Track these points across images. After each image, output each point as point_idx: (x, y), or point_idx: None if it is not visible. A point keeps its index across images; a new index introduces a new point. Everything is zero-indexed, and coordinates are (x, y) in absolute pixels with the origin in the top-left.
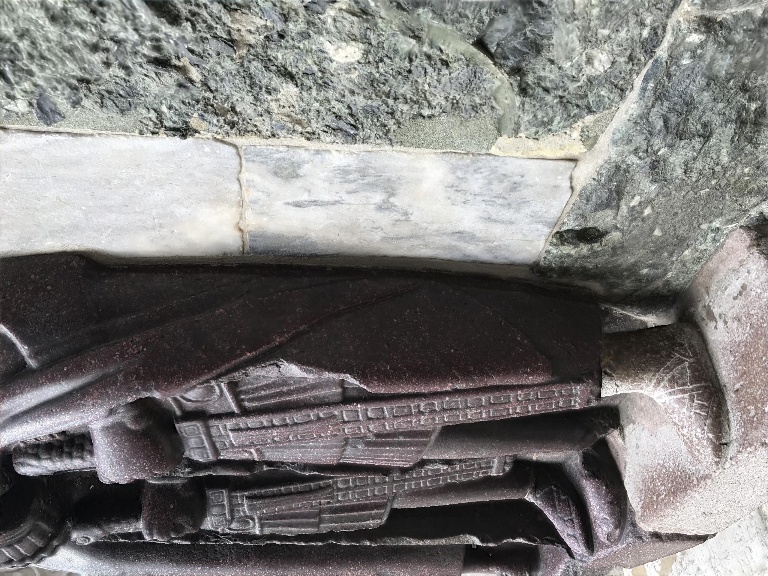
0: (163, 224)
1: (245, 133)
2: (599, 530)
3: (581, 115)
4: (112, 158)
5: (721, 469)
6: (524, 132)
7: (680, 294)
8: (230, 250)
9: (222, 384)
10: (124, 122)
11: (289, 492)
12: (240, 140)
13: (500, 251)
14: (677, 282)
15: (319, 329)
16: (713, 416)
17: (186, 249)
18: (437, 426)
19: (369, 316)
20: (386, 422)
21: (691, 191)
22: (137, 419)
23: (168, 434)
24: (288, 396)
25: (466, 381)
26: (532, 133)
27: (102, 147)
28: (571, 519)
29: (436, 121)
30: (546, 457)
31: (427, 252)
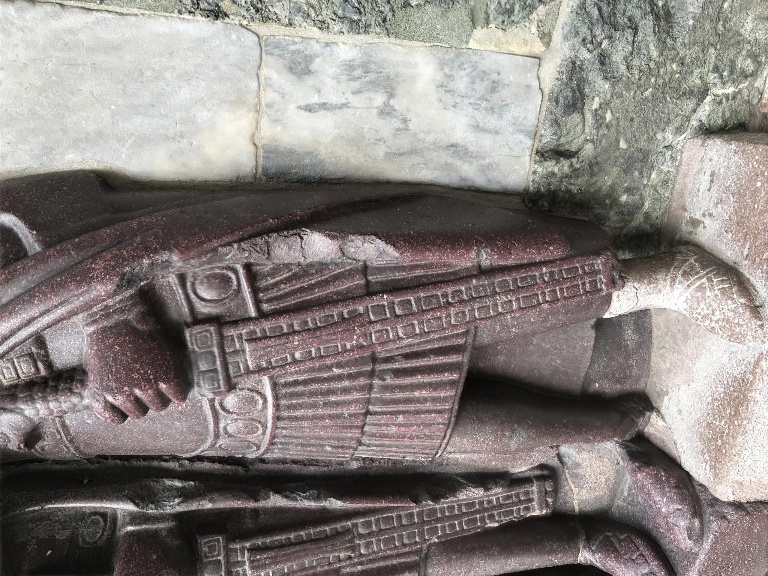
0: (184, 133)
1: (267, 20)
2: (675, 531)
3: (534, 6)
4: (149, 43)
5: (767, 335)
6: (493, 22)
7: (662, 231)
8: (244, 172)
9: (241, 271)
10: (166, 1)
11: (300, 541)
12: (262, 29)
13: (492, 172)
14: (655, 214)
15: (337, 214)
16: (736, 284)
17: (202, 169)
18: (468, 340)
19: (383, 210)
20: (415, 319)
21: (638, 91)
22: (145, 316)
23: (176, 347)
24: (309, 292)
25: (490, 245)
26: (499, 23)
27: (143, 29)
28: (640, 554)
29: (422, 11)
30: (589, 500)
31: (427, 175)
